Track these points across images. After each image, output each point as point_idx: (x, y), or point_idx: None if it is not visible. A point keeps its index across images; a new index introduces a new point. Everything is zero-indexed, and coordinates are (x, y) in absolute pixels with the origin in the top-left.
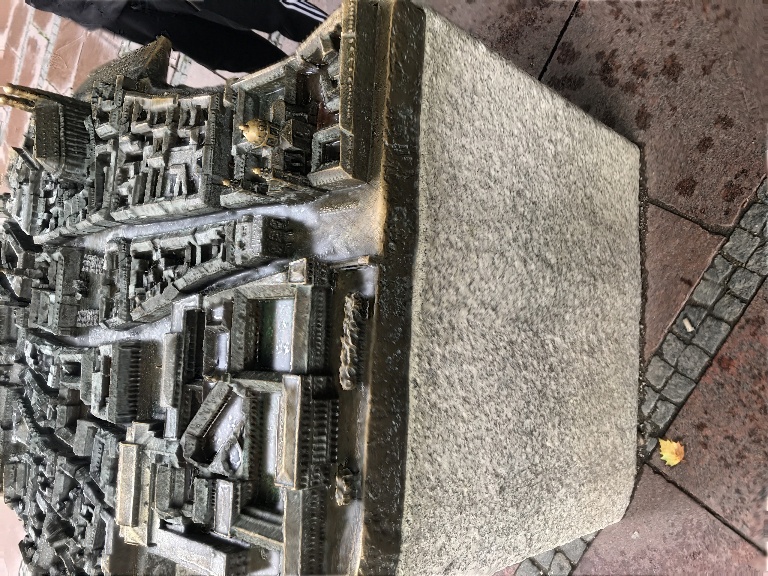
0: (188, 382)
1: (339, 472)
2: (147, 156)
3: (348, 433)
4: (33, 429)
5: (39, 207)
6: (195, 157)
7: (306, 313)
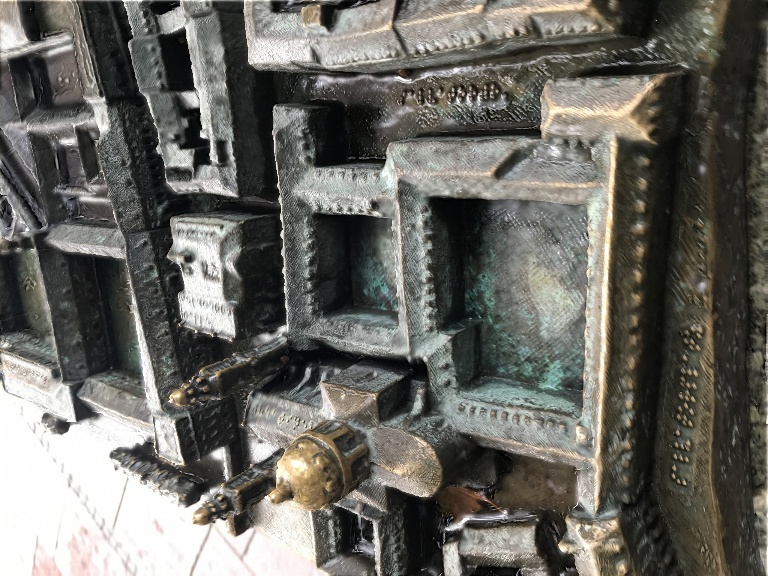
0: (14, 62)
1: (54, 431)
2: None
3: (100, 415)
4: None
5: None
6: None
7: (140, 428)
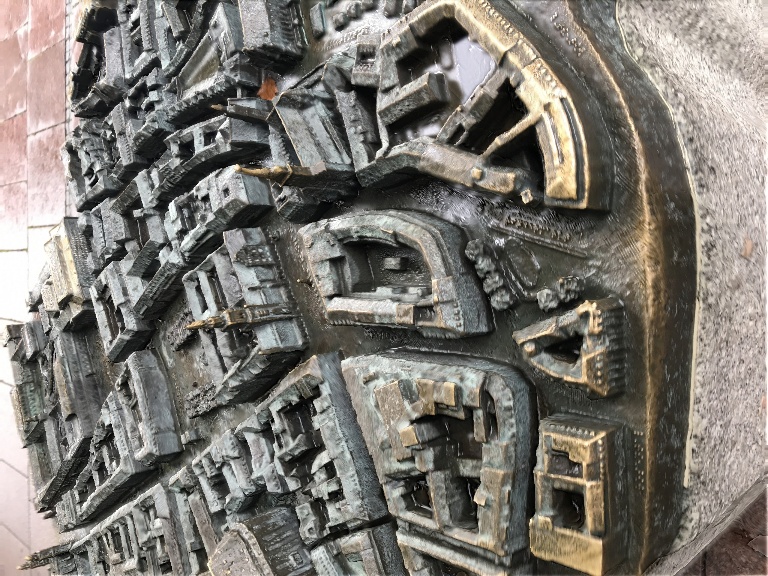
0: None
1: None
2: (148, 570)
3: None
4: (177, 111)
5: (324, 438)
6: (111, 572)
7: None
